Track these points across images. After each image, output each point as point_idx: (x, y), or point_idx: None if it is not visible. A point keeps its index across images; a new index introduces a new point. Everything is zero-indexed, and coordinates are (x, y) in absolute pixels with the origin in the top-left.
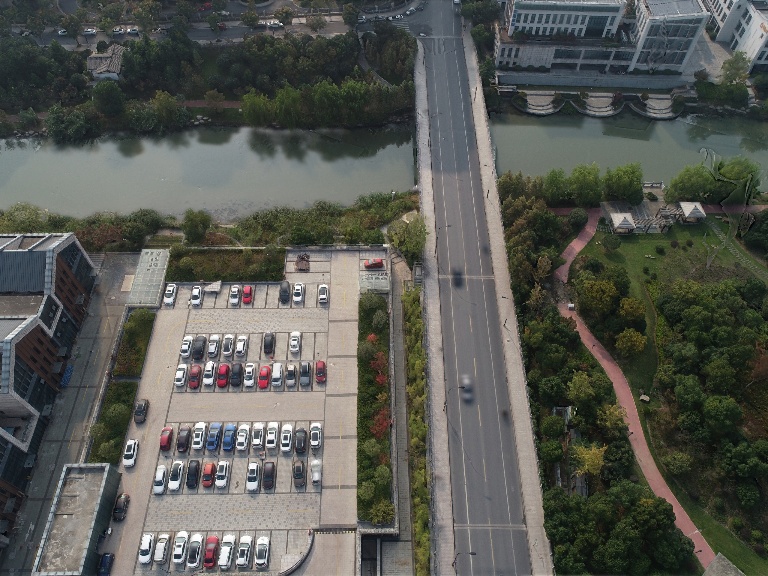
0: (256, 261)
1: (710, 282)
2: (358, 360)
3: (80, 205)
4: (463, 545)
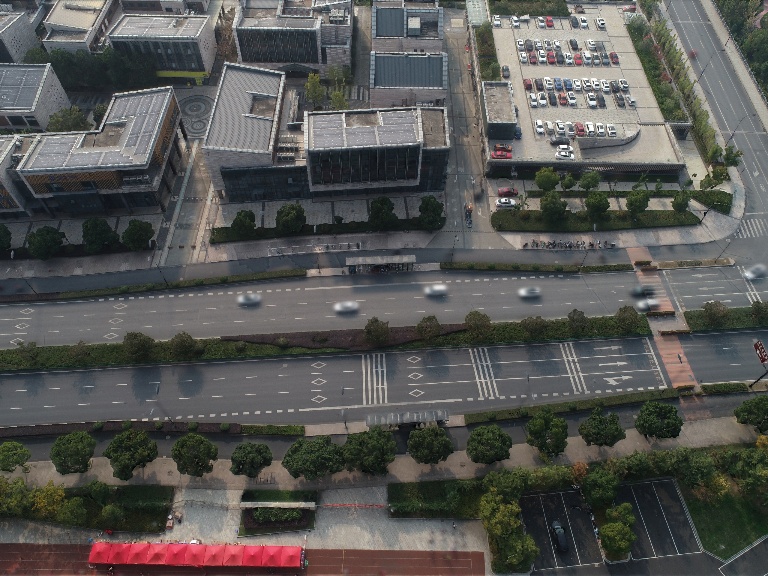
0: (552, 2)
1: None
2: (638, 52)
3: None
4: None
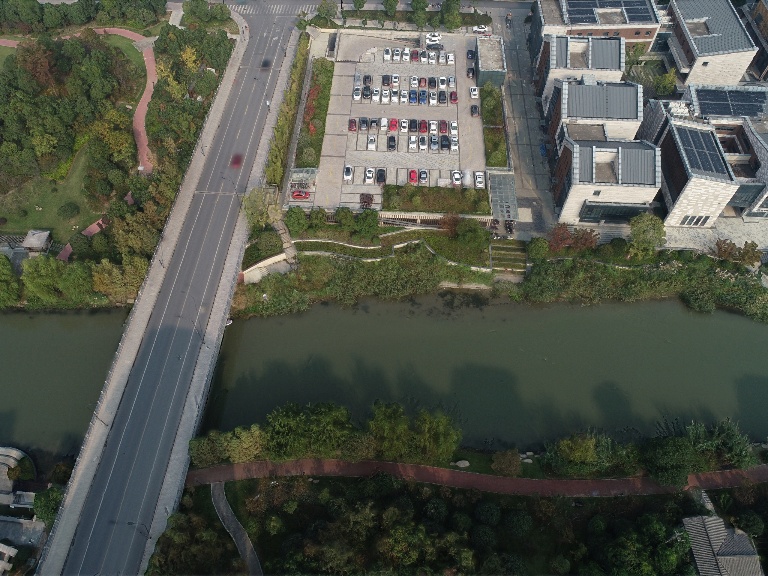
0: None
1: (6, 179)
2: None
3: (628, 326)
4: (278, 63)
